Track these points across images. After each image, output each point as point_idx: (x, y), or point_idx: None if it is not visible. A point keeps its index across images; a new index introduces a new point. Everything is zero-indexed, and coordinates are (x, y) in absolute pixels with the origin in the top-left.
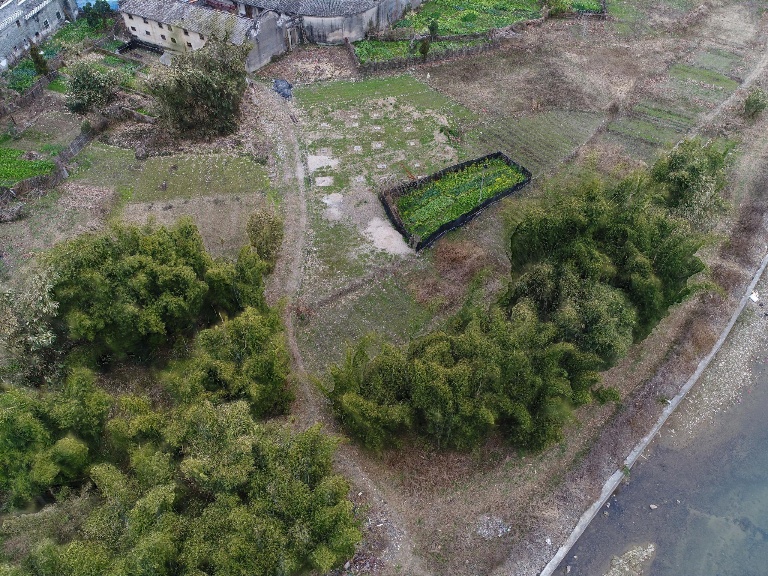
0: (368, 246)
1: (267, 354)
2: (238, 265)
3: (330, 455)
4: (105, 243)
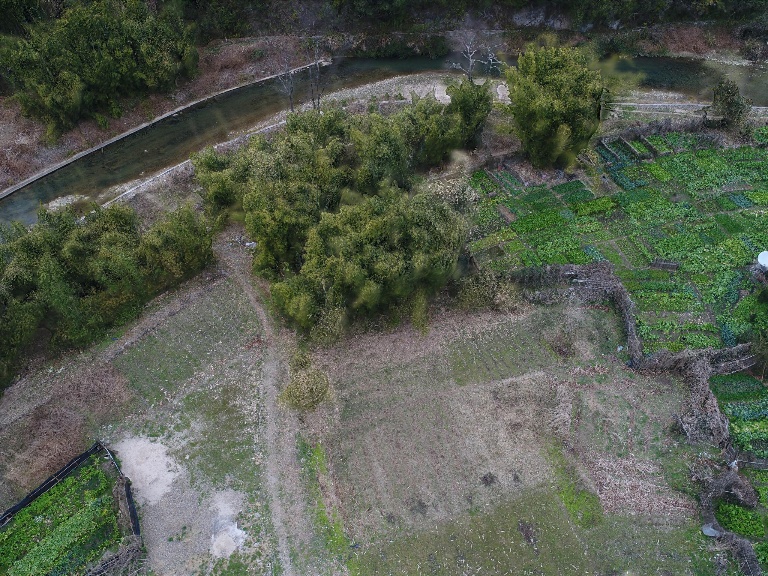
0: (175, 444)
1: (250, 194)
2: (309, 294)
3: (222, 246)
4: (415, 217)
